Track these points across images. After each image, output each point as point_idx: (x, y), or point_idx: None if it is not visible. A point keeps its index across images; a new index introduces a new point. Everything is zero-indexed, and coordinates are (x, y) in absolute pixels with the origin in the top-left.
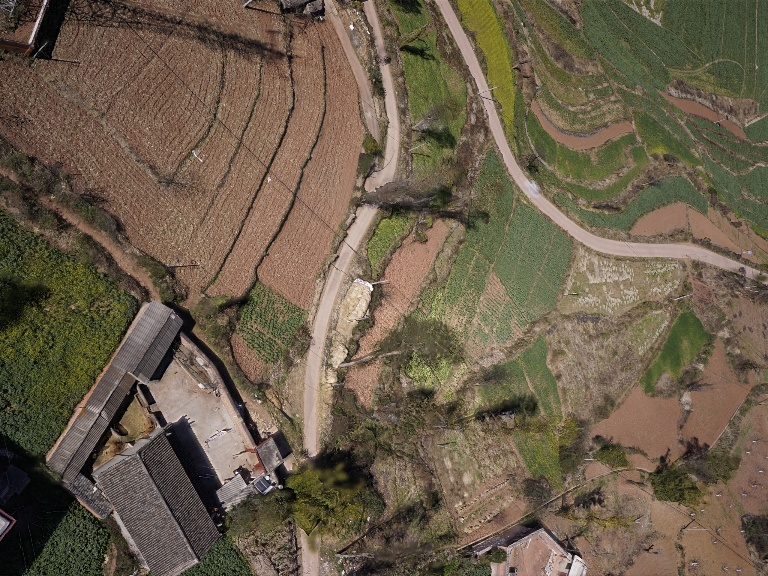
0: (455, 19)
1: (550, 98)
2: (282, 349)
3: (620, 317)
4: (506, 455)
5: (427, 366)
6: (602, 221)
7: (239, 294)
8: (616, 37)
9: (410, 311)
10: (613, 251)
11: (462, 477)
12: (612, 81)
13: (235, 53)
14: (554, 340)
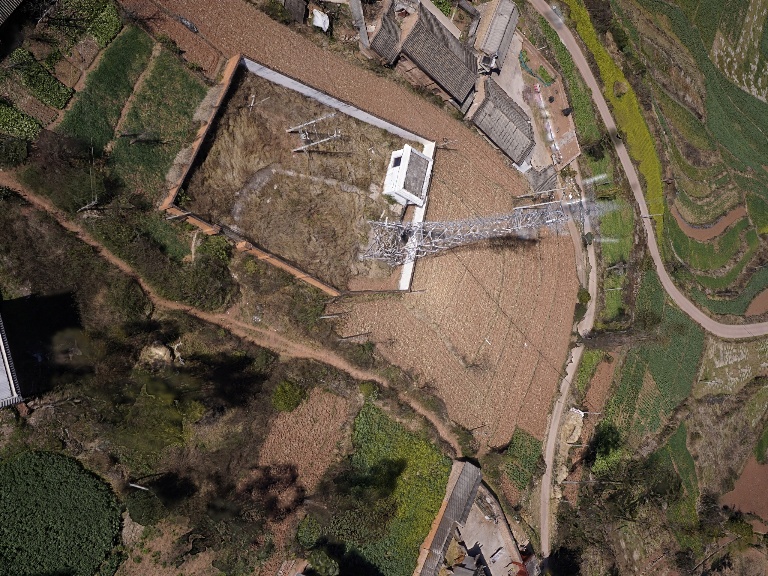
0: (625, 152)
1: (683, 196)
2: (528, 476)
3: (738, 394)
4: (662, 532)
5: (605, 461)
6: (725, 308)
7: (508, 441)
8: (731, 121)
9: (598, 421)
10: (733, 335)
11: (633, 554)
12: (729, 168)
13: (509, 251)
14: (691, 424)
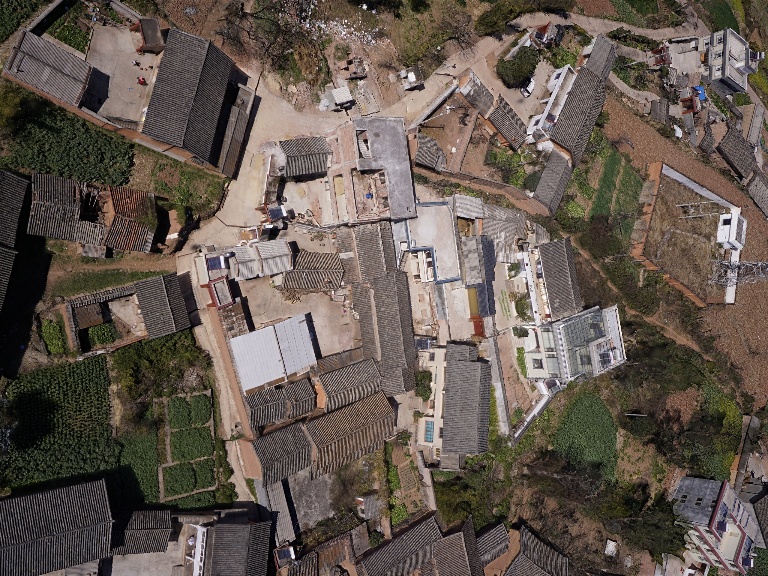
0: None
1: None
2: None
3: None
4: None
5: None
6: None
7: (765, 405)
8: None
9: None
10: None
11: None
12: None
13: None
14: None
